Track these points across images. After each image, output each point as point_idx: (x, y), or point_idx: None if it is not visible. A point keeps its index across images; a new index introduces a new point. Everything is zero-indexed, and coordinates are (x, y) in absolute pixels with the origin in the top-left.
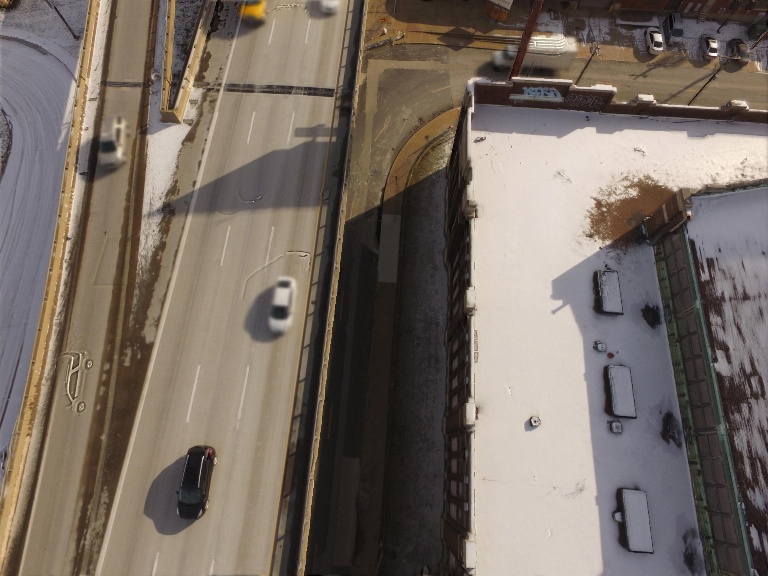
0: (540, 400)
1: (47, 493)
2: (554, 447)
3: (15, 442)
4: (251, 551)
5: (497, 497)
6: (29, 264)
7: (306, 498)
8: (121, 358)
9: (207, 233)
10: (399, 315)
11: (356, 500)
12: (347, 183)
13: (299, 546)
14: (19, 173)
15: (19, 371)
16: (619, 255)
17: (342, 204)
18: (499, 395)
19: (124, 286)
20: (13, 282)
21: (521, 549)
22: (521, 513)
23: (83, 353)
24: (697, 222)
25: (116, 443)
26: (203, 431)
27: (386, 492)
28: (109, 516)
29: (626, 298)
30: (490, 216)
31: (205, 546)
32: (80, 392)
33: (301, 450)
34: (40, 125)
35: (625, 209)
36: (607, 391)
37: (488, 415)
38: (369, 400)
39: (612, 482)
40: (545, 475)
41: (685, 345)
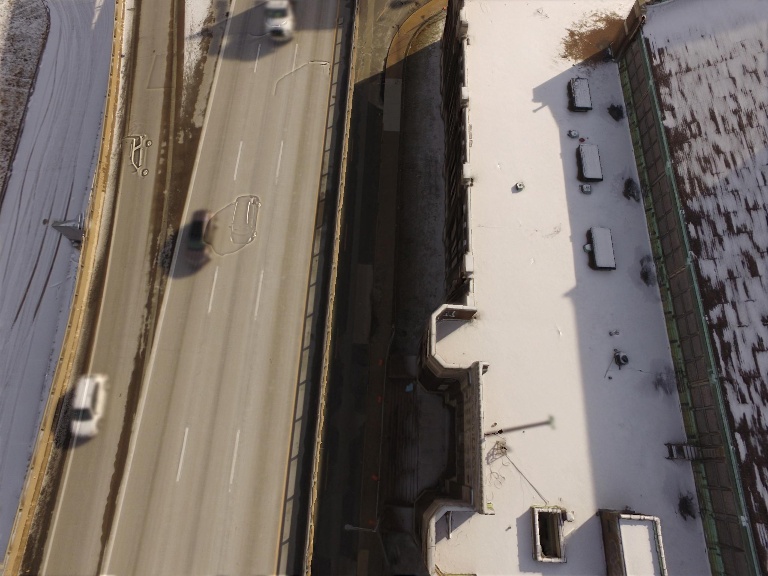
0: (524, 172)
1: (123, 230)
2: (536, 203)
3: (95, 190)
4: (293, 264)
5: (490, 238)
6: (74, 119)
7: (336, 221)
8: (175, 138)
9: (241, 49)
10: (403, 156)
11: (370, 295)
12: (358, 9)
13: (332, 252)
14: (59, 48)
15: (72, 202)
16: (589, 70)
17: (355, 23)
18: (490, 169)
19: (173, 88)
20: (61, 134)
21: (510, 272)
22: (510, 248)
23: (143, 136)
24: (651, 24)
25: (177, 196)
26: (248, 186)
27: (396, 288)
28: (175, 243)
29: (595, 100)
30: (480, 43)
31: (255, 261)
32: (143, 162)
33: (329, 196)
34: (75, 9)
35: (594, 37)
36: (579, 163)
37: (481, 183)
38: (379, 221)
39: (583, 226)
40: (529, 222)
41: (642, 125)
